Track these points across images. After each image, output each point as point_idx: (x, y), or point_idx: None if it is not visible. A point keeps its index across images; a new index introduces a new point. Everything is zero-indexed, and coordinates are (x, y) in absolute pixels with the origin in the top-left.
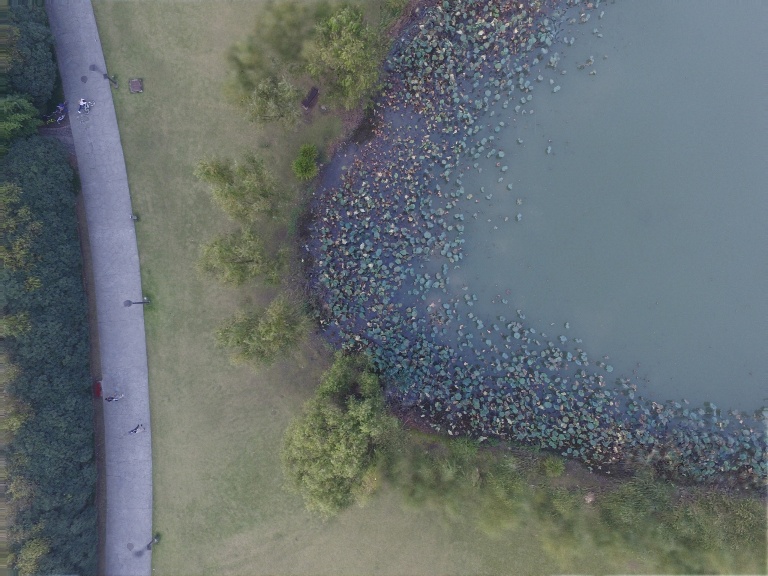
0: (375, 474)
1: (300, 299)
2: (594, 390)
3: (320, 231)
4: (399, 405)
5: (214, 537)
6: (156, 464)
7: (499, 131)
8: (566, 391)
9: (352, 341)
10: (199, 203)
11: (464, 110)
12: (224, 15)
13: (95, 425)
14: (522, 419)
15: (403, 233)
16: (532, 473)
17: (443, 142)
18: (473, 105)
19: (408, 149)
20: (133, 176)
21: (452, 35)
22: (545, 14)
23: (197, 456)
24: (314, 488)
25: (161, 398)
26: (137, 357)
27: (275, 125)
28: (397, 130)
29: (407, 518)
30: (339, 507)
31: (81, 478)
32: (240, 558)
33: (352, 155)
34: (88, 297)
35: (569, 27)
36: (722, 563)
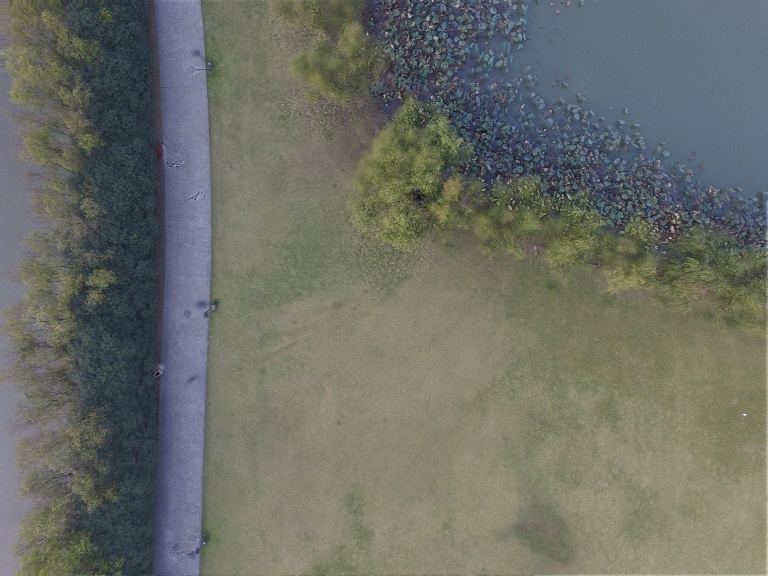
0: (434, 249)
1: (363, 75)
2: (653, 171)
3: (386, 3)
4: (460, 179)
5: (273, 303)
6: (216, 231)
7: None
8: (625, 171)
9: (415, 114)
10: None
11: None
12: None
13: (158, 182)
14: (582, 195)
15: (469, 8)
16: (589, 252)
17: None
18: None
19: None
20: None
21: None
22: None
23: (258, 223)
24: (373, 260)
25: (222, 165)
26: (199, 124)
27: None
28: None
29: (464, 293)
30: (397, 280)
31: (146, 224)
32: (298, 325)
33: None
34: (153, 56)
35: None
36: None
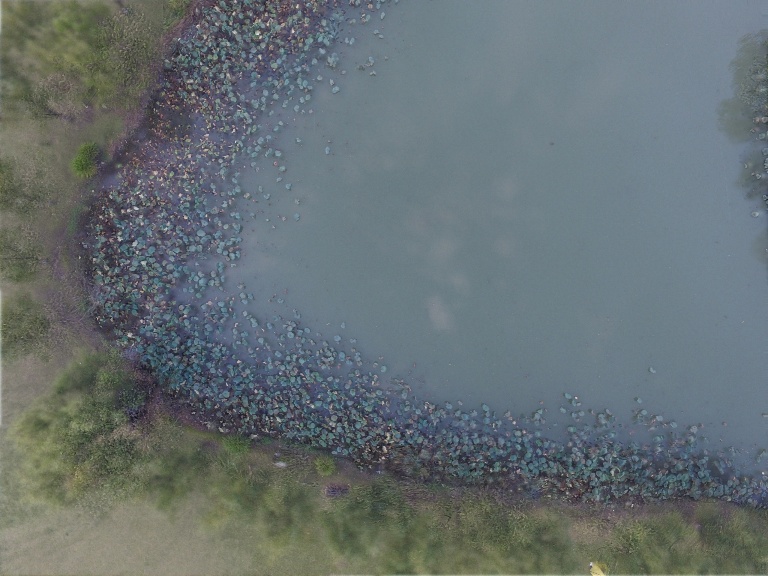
0: (149, 470)
1: (79, 296)
2: (366, 389)
3: (95, 228)
4: (171, 402)
5: None
6: None
7: (277, 130)
8: (338, 390)
9: (125, 338)
10: None
11: (242, 109)
12: (6, 14)
13: None
14: (291, 417)
15: (177, 231)
16: (303, 471)
17: (221, 141)
18: (250, 104)
19: (184, 148)
20: None
21: (230, 35)
22: (322, 14)
23: None
24: (87, 484)
25: None
26: None
27: (54, 123)
28: (175, 129)
29: (179, 515)
30: (112, 503)
31: None
32: (10, 552)
33: (132, 153)
34: None
35: (349, 27)
36: (493, 564)
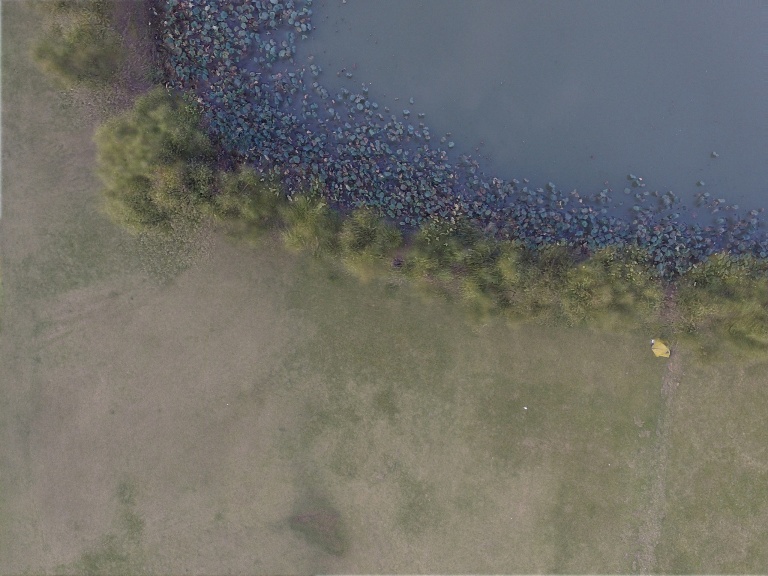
0: (215, 239)
1: (148, 65)
2: (435, 162)
3: None
4: (239, 169)
5: (49, 292)
6: None
7: None
8: (407, 162)
9: (195, 104)
10: None
11: None
12: None
13: None
14: (361, 186)
15: None
16: (370, 243)
17: None
18: None
19: None
20: None
21: None
22: None
23: (35, 211)
24: (152, 250)
25: (1, 153)
26: None
27: None
28: None
29: (245, 284)
30: (177, 270)
31: None
32: (74, 313)
33: None
34: None
35: None
36: (556, 339)
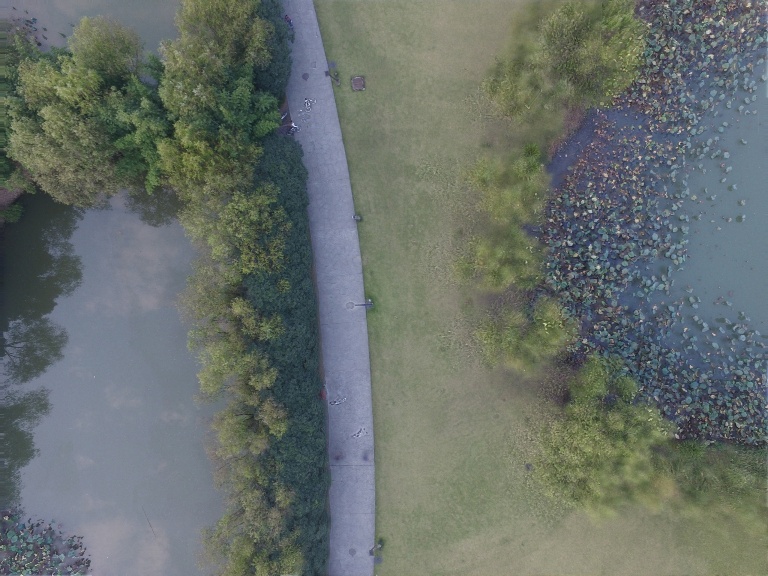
0: (599, 478)
1: (521, 301)
2: None
3: (546, 232)
4: (626, 409)
5: (440, 542)
6: (379, 469)
7: (724, 132)
8: None
9: (578, 344)
10: (421, 203)
11: (689, 110)
12: (447, 12)
13: (326, 429)
14: (751, 423)
15: (630, 235)
16: (758, 477)
17: (667, 143)
18: (699, 105)
19: (634, 149)
20: (355, 176)
21: (678, 34)
22: None
23: (423, 460)
24: (539, 492)
25: (385, 402)
26: (360, 360)
27: (498, 124)
28: (622, 130)
29: (631, 522)
30: (563, 512)
31: (323, 483)
32: (467, 563)
33: (575, 155)
34: (316, 299)
35: None
36: None
